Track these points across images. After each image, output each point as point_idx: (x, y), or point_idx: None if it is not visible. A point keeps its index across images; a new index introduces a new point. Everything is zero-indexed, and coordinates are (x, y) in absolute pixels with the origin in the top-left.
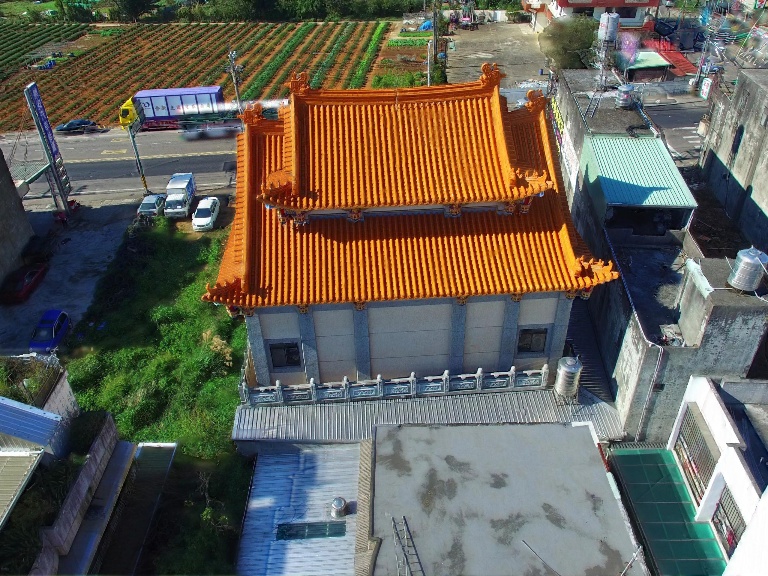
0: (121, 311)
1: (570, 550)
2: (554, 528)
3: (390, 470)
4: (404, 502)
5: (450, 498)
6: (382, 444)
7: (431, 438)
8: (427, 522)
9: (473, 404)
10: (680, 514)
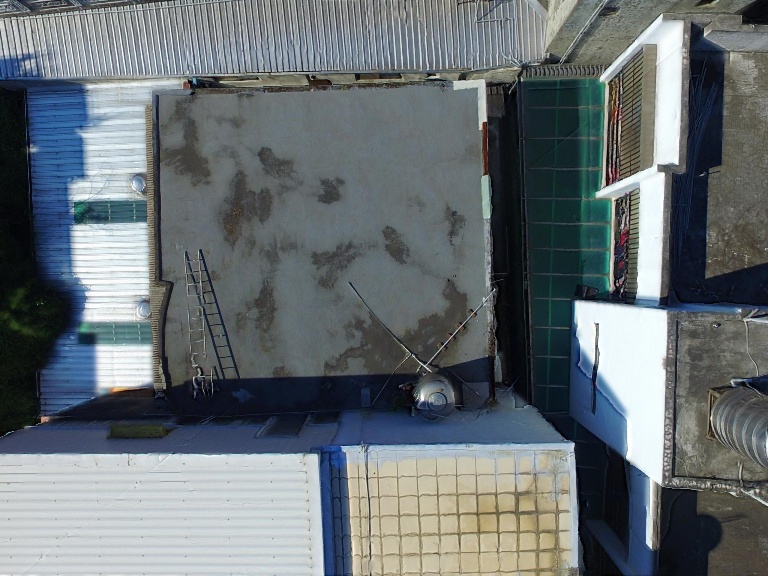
0: None
1: (406, 294)
2: (392, 264)
3: (180, 175)
4: (200, 228)
5: (262, 220)
6: (167, 128)
7: (239, 115)
8: (230, 258)
9: (328, 4)
10: (580, 186)
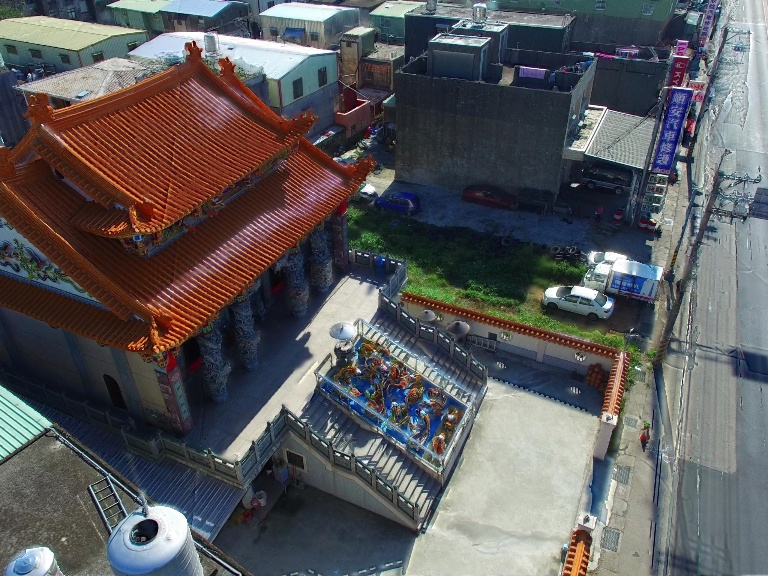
0: None
1: None
2: None
3: None
4: None
5: None
6: None
7: None
8: None
9: None
10: None
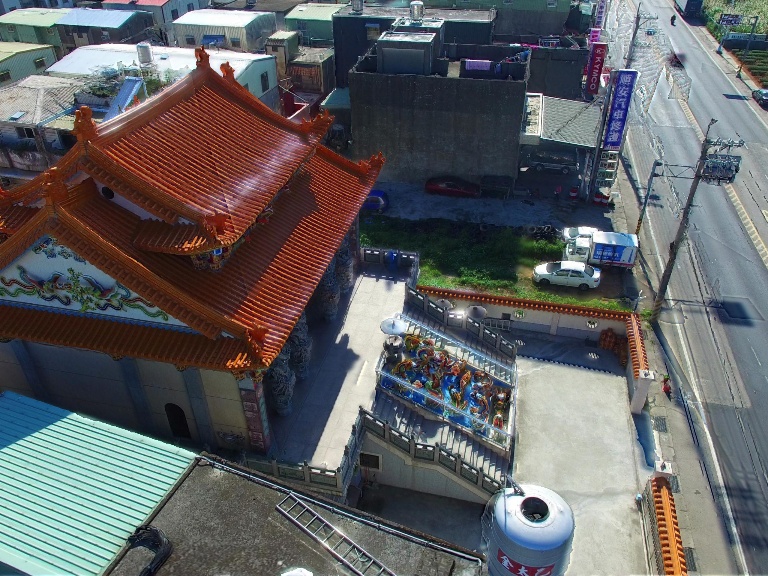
0: None
1: None
2: None
3: None
4: None
5: None
6: None
7: None
8: None
9: None
10: None
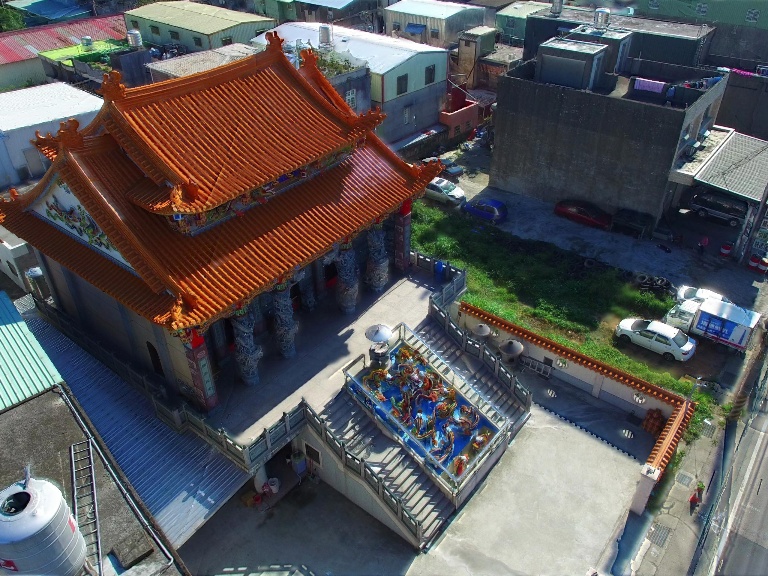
0: (495, 246)
1: None
2: None
3: None
4: None
5: None
6: None
7: None
8: None
9: None
10: None
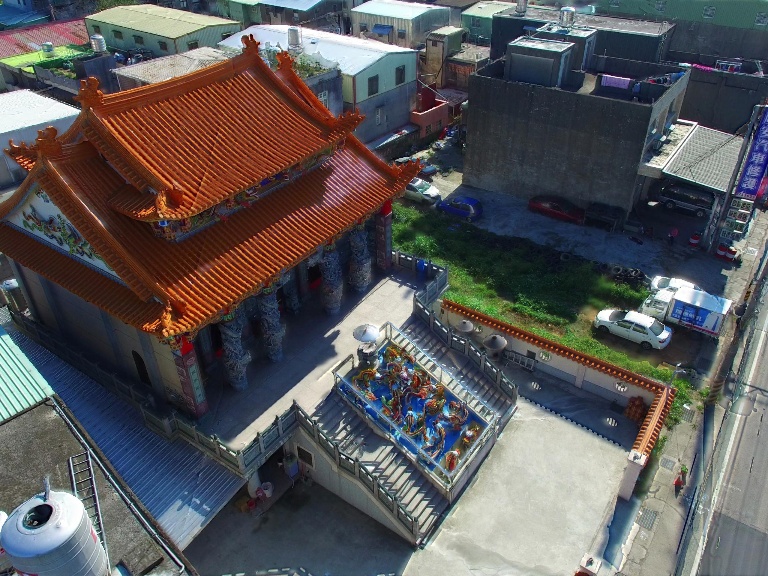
0: None
1: None
2: None
3: None
4: None
5: None
6: None
7: None
8: None
9: None
10: None
